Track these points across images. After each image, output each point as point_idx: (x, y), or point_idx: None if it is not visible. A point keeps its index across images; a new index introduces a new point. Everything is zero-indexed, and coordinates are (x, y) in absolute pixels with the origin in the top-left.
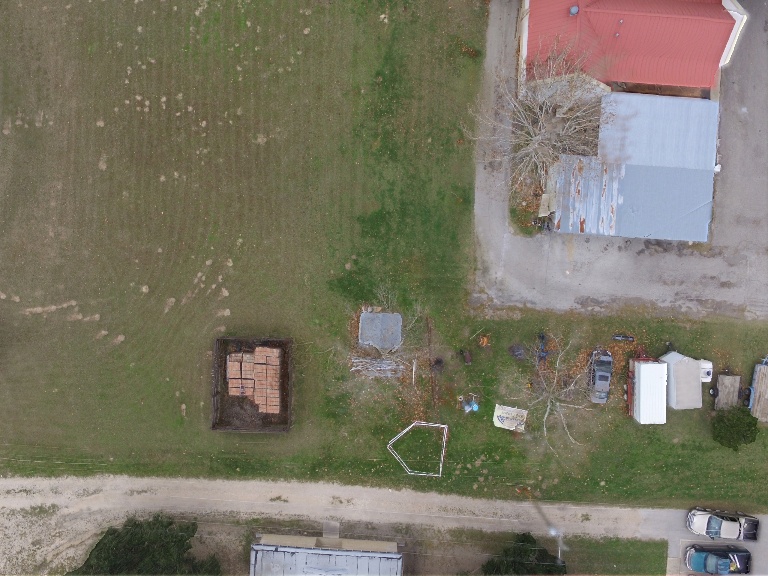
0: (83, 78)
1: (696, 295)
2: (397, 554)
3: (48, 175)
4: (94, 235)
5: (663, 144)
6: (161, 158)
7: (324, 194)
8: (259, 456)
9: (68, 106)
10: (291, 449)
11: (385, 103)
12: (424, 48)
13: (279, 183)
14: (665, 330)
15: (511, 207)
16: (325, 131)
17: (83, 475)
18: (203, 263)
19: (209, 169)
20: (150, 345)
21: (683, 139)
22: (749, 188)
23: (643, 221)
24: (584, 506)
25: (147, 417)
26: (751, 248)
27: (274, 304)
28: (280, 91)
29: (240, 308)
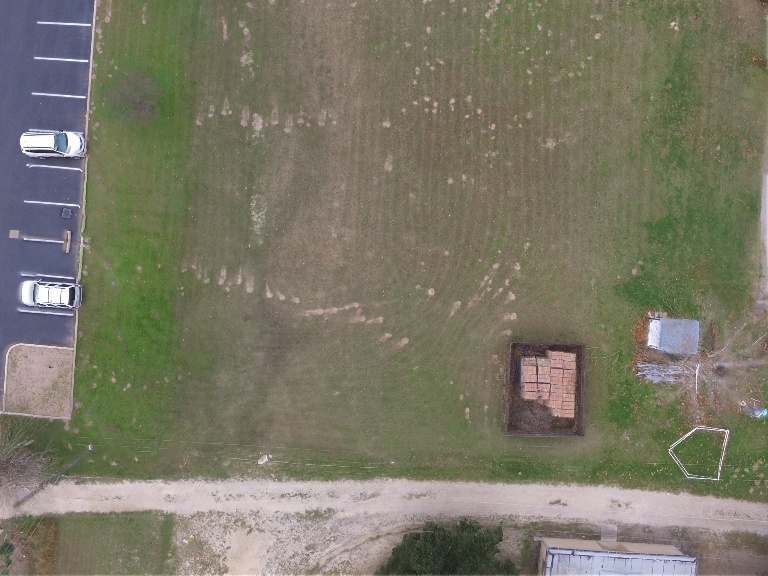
0: (369, 78)
1: None
2: (691, 557)
3: (331, 175)
4: (378, 237)
5: None
6: (449, 160)
7: (612, 199)
8: (542, 460)
9: (353, 106)
10: (573, 453)
11: (674, 110)
12: (714, 56)
13: (567, 188)
14: None
15: None
16: (614, 137)
17: (361, 479)
18: (490, 266)
19: (497, 172)
20: (434, 348)
21: None
22: None
23: None
24: None
25: (430, 420)
26: None
27: (561, 308)
28: (570, 96)
29: (527, 312)
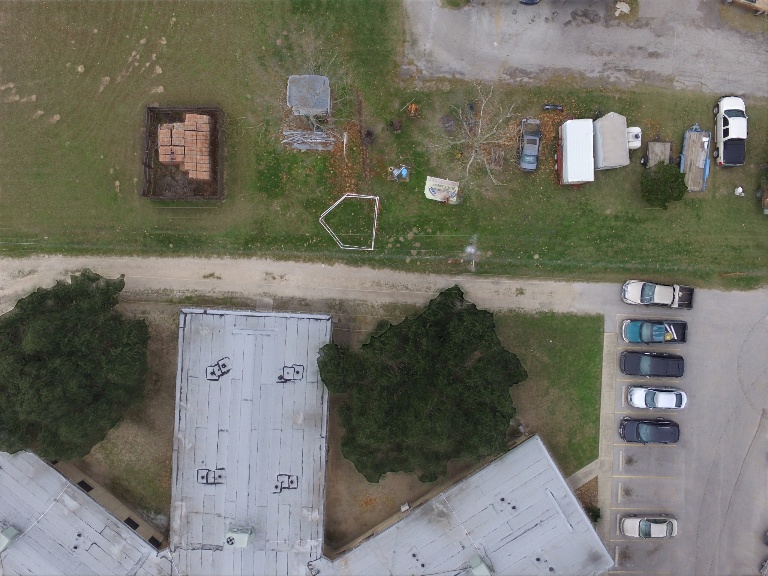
0: None
1: (624, 65)
2: (326, 315)
3: None
4: (32, 19)
5: None
6: None
7: None
8: (192, 231)
9: None
10: (224, 224)
11: None
12: None
13: None
14: (594, 100)
15: None
16: None
17: (18, 256)
18: (137, 42)
19: None
20: (85, 124)
21: None
22: None
23: None
24: (518, 280)
25: (81, 195)
26: (678, 19)
27: (207, 80)
28: None
29: (173, 85)
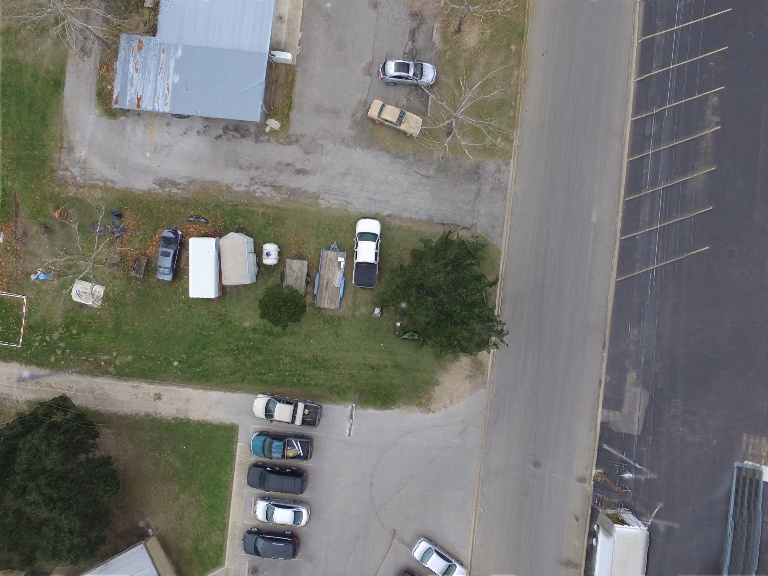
0: None
1: (270, 181)
2: None
3: None
4: None
5: (220, 28)
6: None
7: None
8: None
9: None
10: None
11: None
12: None
13: None
14: (238, 214)
15: (97, 90)
16: None
17: None
18: None
19: None
20: None
21: (239, 23)
22: (329, 80)
23: (197, 100)
24: (157, 385)
25: None
26: (328, 138)
27: None
28: None
29: None
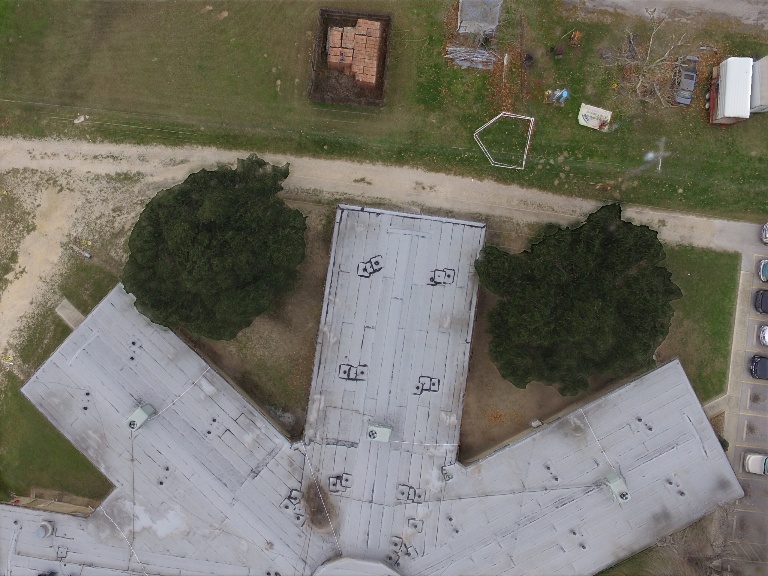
0: None
1: None
2: (481, 223)
3: None
4: None
5: None
6: None
7: None
8: (347, 135)
9: None
10: (379, 131)
11: None
12: None
13: None
14: (747, 46)
15: None
16: None
17: (172, 144)
18: None
19: None
20: (252, 22)
21: None
22: None
23: None
24: (661, 212)
25: (242, 90)
26: None
27: None
28: None
29: None
